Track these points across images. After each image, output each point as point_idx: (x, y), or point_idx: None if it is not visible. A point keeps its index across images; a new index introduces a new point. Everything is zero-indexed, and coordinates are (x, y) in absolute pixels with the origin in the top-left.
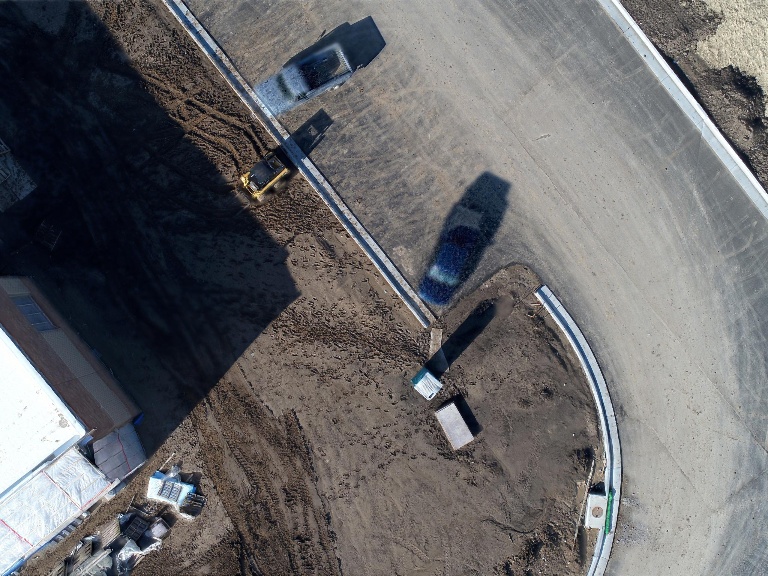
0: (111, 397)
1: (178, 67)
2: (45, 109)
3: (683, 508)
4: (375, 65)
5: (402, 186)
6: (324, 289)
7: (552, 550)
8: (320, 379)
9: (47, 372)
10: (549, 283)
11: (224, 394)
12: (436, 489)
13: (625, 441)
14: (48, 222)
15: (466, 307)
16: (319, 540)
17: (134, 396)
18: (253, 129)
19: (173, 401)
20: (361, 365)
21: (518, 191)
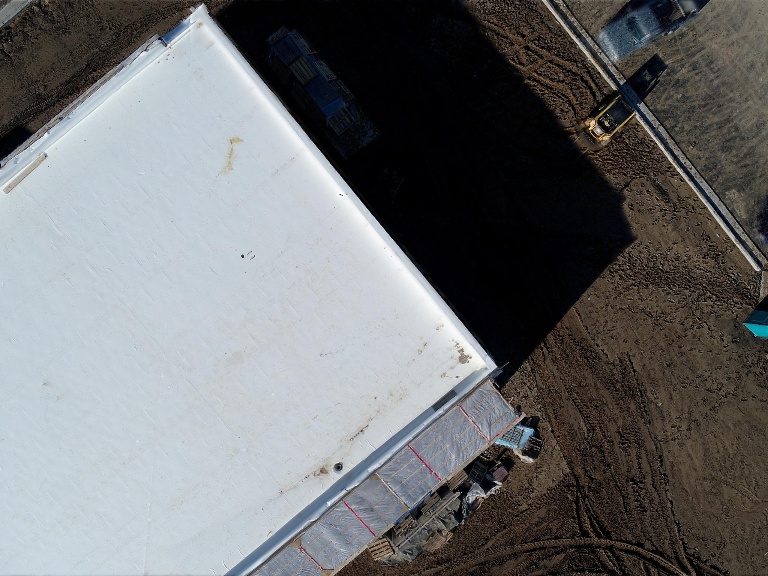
0: None
1: (516, 13)
2: (387, 56)
3: None
4: (708, 10)
5: (734, 130)
6: (659, 233)
7: None
8: (654, 323)
9: None
10: None
11: (560, 338)
12: (765, 431)
13: None
14: (391, 168)
15: None
16: (651, 483)
17: None
18: (590, 74)
19: (512, 346)
20: (694, 308)
21: None
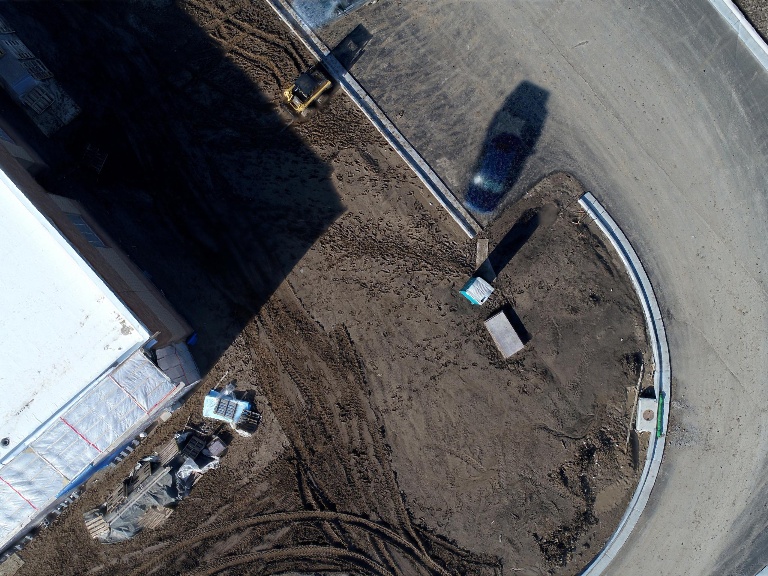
0: (166, 313)
1: None
2: (86, 33)
3: (733, 408)
4: None
5: (443, 98)
6: (370, 203)
7: (605, 454)
8: (369, 293)
9: (107, 280)
10: (592, 189)
11: (275, 311)
12: (488, 399)
13: (673, 344)
14: (94, 146)
15: (511, 217)
16: (374, 453)
17: (186, 316)
18: (293, 46)
19: (225, 320)
20: (409, 278)
21: (558, 99)
